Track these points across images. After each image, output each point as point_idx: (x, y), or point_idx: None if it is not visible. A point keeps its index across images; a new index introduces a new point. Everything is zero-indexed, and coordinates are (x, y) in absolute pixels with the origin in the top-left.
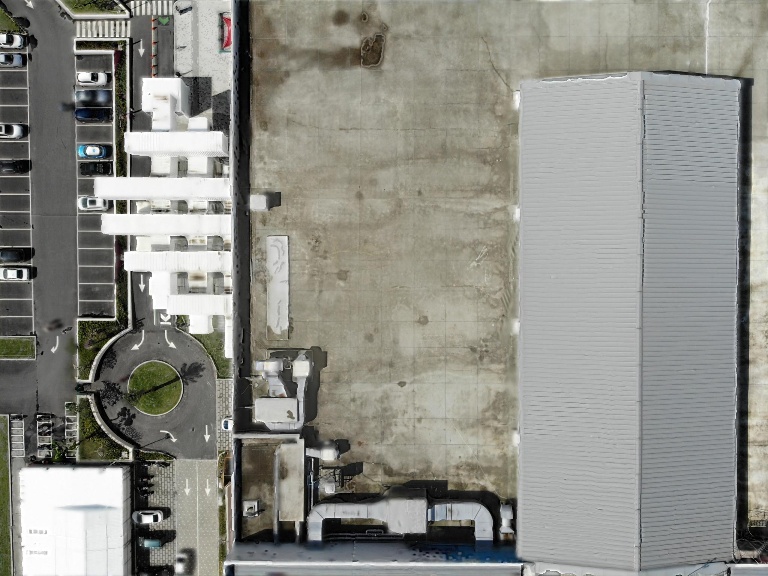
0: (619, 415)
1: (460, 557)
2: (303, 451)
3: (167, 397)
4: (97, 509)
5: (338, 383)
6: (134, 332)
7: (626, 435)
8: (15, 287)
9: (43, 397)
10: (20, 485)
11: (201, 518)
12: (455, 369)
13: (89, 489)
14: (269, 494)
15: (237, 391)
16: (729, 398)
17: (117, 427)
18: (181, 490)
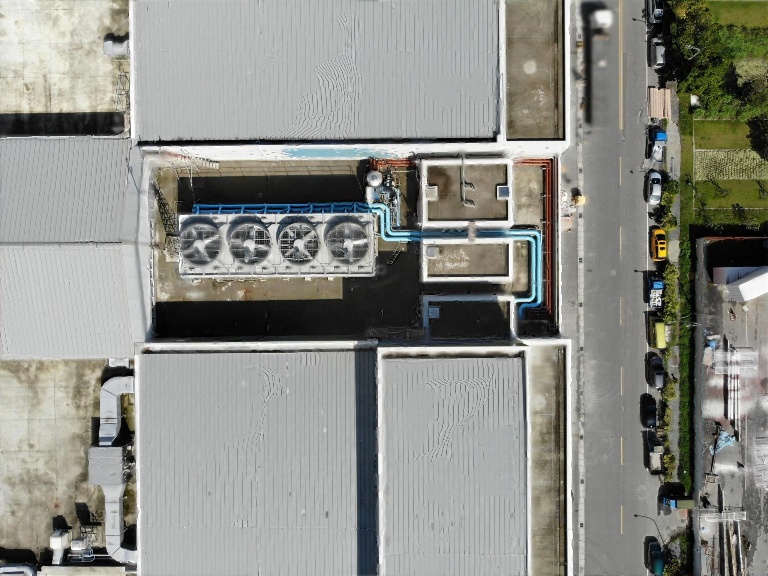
0: None
1: None
2: (54, 568)
3: None
4: None
5: None
6: None
7: None
8: None
9: None
10: None
11: None
12: None
13: None
14: None
15: None
16: None
17: None
18: None
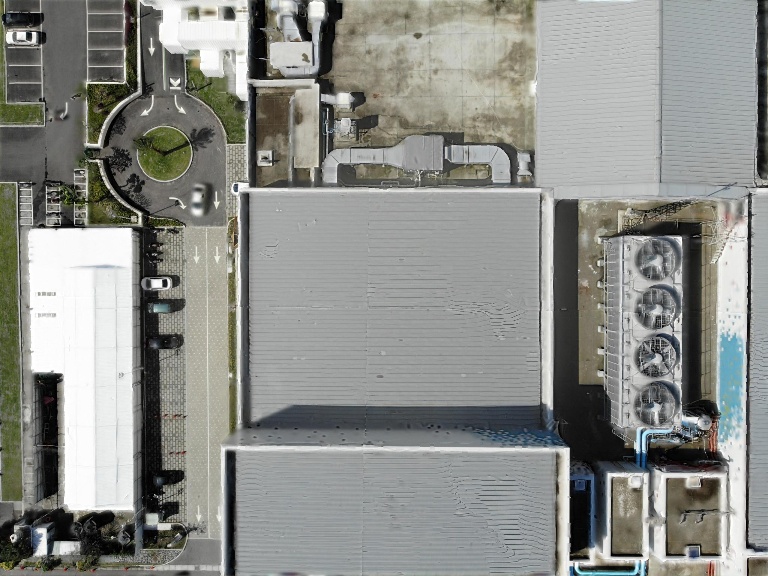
0: (639, 27)
1: (478, 187)
2: (318, 96)
3: (177, 162)
4: (106, 268)
5: (353, 35)
6: (143, 97)
7: (646, 45)
8: (24, 53)
9: (52, 164)
10: (29, 246)
11: (210, 286)
12: (471, 19)
13: (98, 250)
14: (284, 144)
15: (251, 38)
16: (750, 21)
17: (126, 194)
18: (190, 258)
